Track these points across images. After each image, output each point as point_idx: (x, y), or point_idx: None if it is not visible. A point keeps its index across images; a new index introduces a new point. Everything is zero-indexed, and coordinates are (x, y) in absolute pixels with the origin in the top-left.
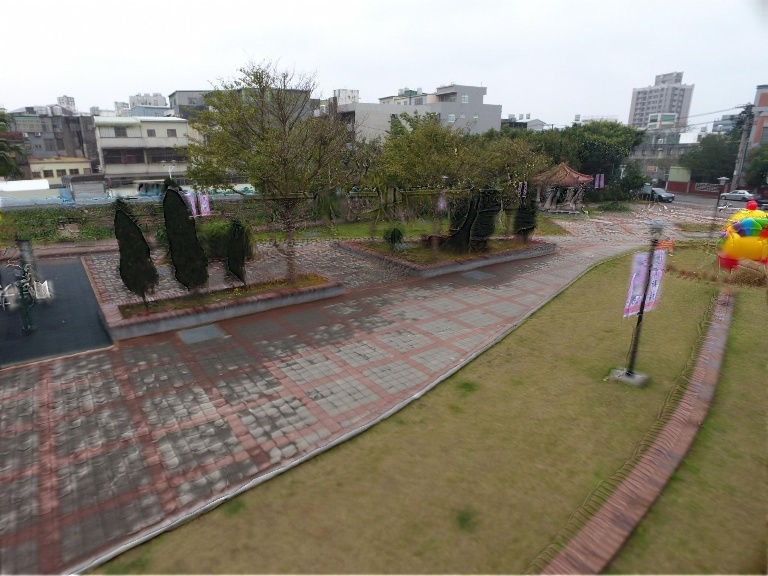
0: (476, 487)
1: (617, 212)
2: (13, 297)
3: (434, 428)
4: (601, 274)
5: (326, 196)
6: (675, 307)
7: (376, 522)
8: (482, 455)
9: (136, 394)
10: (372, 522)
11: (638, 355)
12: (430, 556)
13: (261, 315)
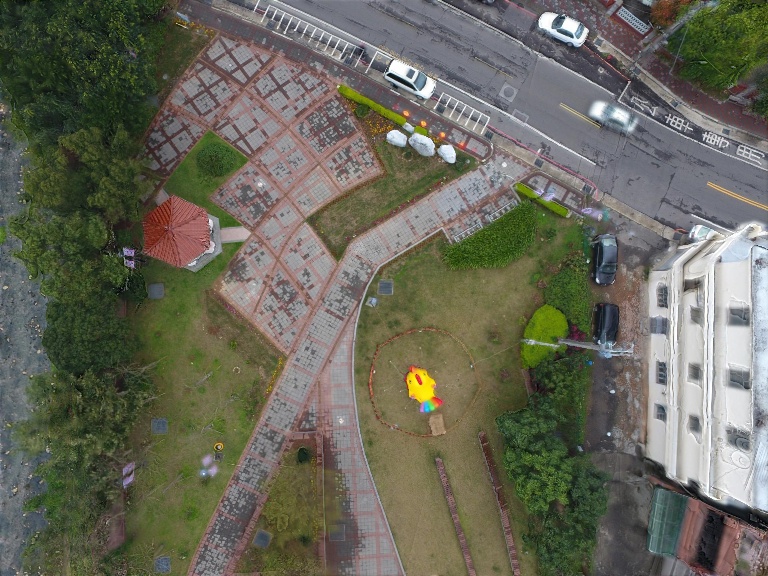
0: None
1: (218, 168)
2: None
3: None
4: (378, 468)
5: (110, 552)
6: (432, 495)
7: None
8: None
9: None
10: None
11: (452, 568)
12: None
13: None
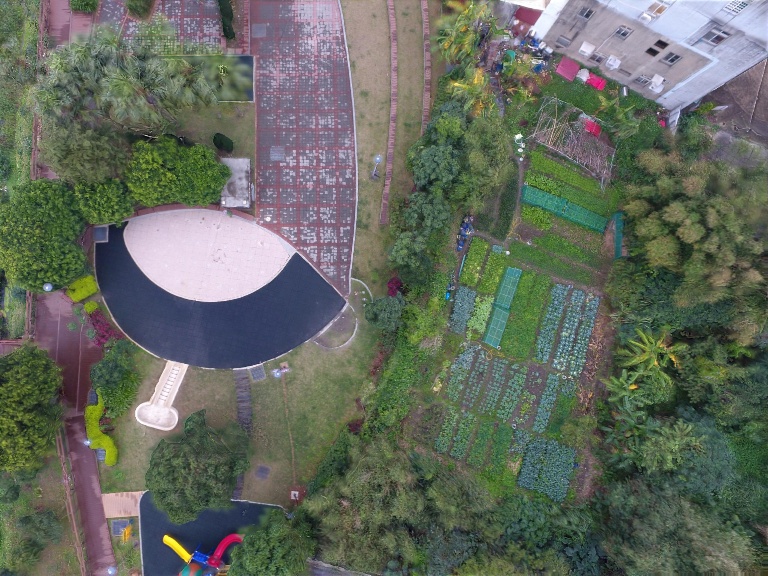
0: (371, 8)
1: None
2: (226, 71)
3: (352, 2)
4: None
5: None
6: None
7: (367, 28)
8: (365, 0)
9: (294, 55)
10: (367, 28)
11: None
12: (378, 25)
13: (255, 8)
